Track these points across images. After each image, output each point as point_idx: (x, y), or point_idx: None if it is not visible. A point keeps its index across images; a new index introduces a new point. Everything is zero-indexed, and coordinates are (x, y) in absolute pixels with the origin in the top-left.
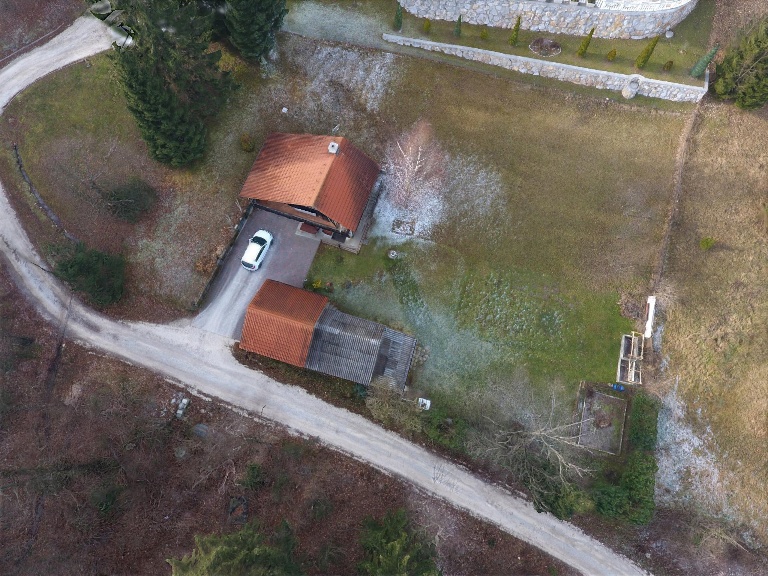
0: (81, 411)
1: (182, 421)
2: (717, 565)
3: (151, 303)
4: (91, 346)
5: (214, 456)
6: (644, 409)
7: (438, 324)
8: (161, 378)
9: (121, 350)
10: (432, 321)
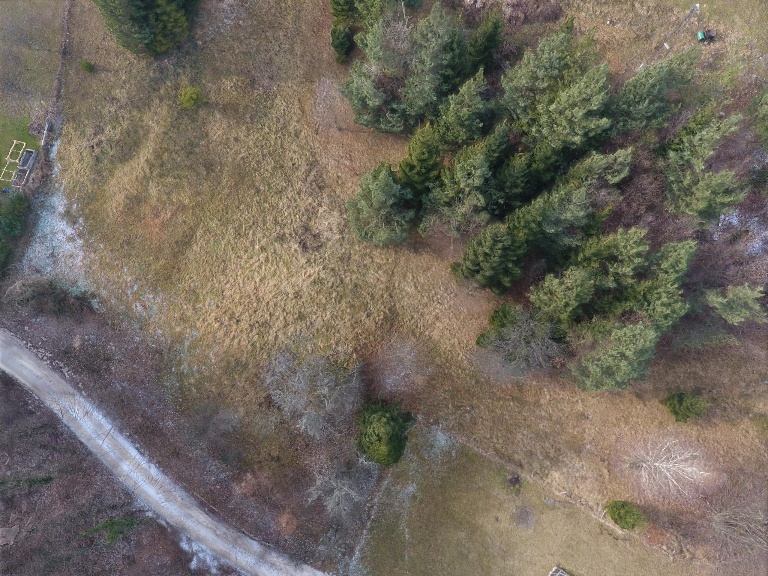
0: None
1: None
2: (74, 330)
3: None
4: None
5: None
6: None
7: None
8: None
9: None
10: None
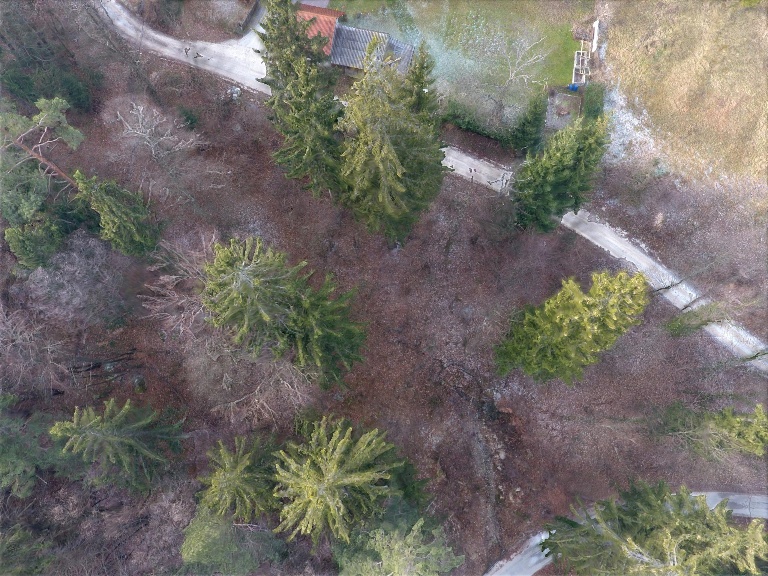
0: (160, 91)
1: (237, 105)
2: (656, 208)
3: (205, 29)
4: (162, 55)
5: (263, 132)
6: (592, 89)
7: (431, 46)
8: (218, 77)
9: (185, 59)
10: (426, 44)
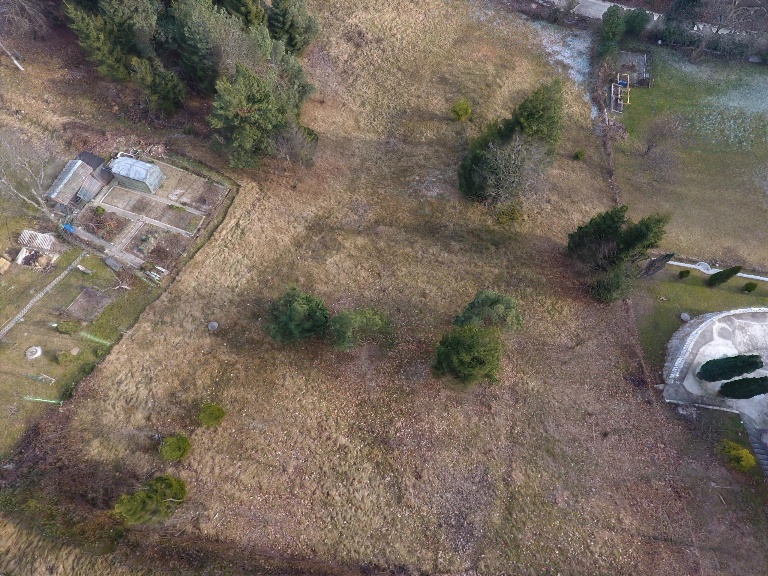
0: None
1: None
2: None
3: None
4: None
5: None
6: None
7: None
8: None
9: None
10: None
